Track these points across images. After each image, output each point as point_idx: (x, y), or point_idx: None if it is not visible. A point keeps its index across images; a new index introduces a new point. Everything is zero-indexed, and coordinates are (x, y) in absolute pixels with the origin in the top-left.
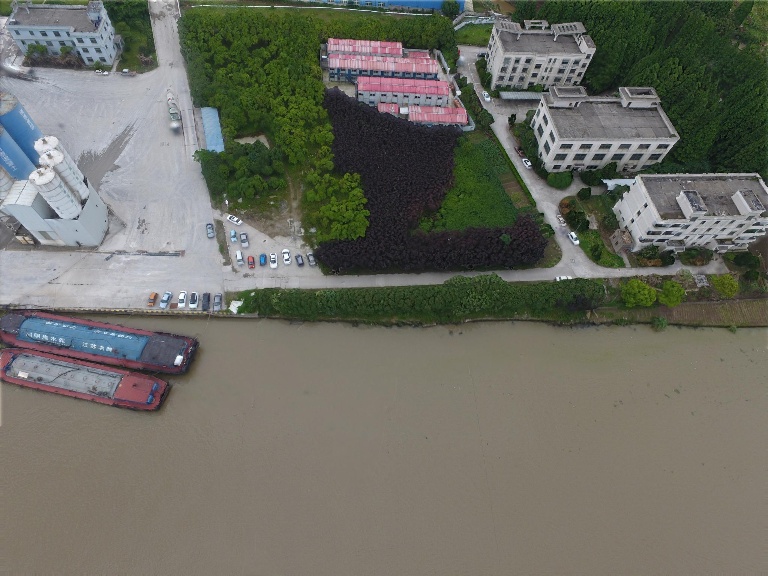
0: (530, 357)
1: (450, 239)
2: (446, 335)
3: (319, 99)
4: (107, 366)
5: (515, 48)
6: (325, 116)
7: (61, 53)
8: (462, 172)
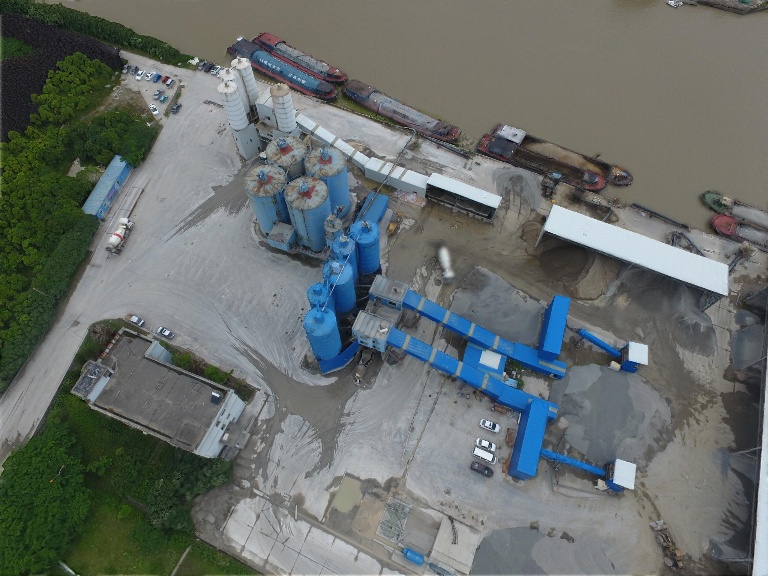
0: None
1: (28, 31)
2: None
3: None
4: (282, 59)
5: None
6: None
7: None
8: None
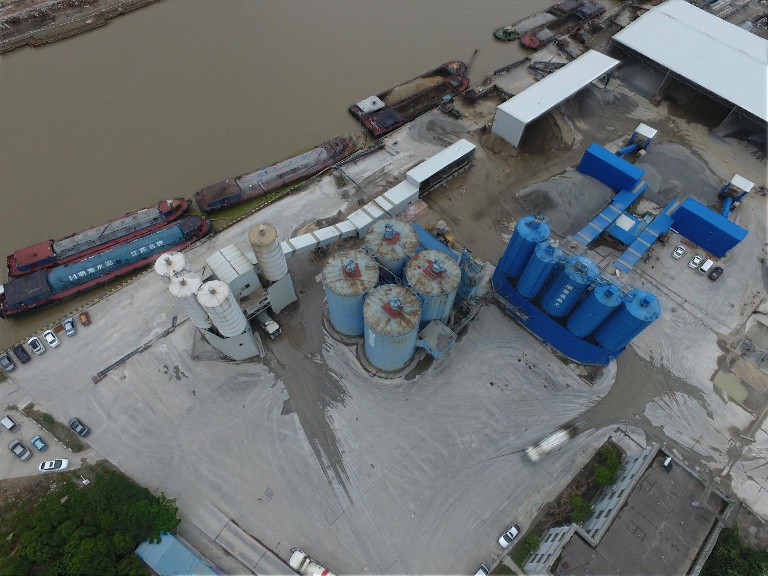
0: None
1: None
2: None
3: None
4: (85, 255)
5: None
6: None
7: None
8: None
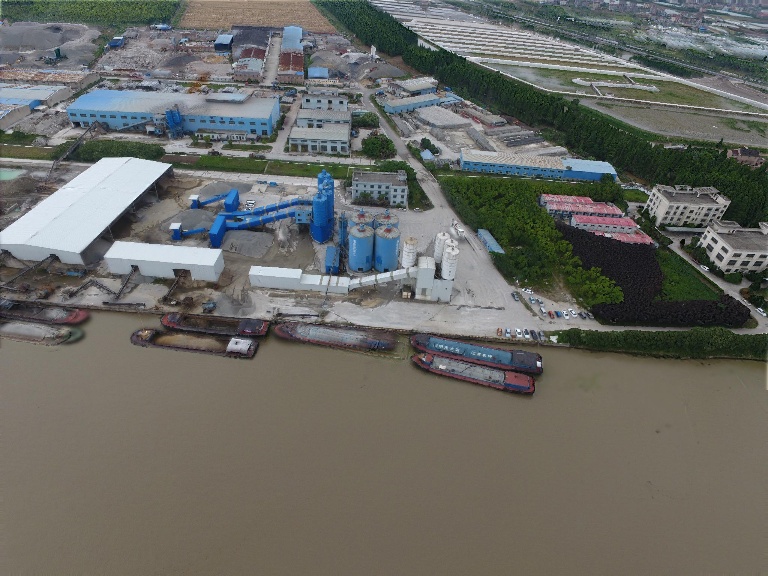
0: (766, 381)
1: (683, 305)
2: (700, 365)
3: (553, 226)
4: (488, 367)
5: (674, 200)
6: (561, 236)
7: (377, 198)
8: (666, 270)
